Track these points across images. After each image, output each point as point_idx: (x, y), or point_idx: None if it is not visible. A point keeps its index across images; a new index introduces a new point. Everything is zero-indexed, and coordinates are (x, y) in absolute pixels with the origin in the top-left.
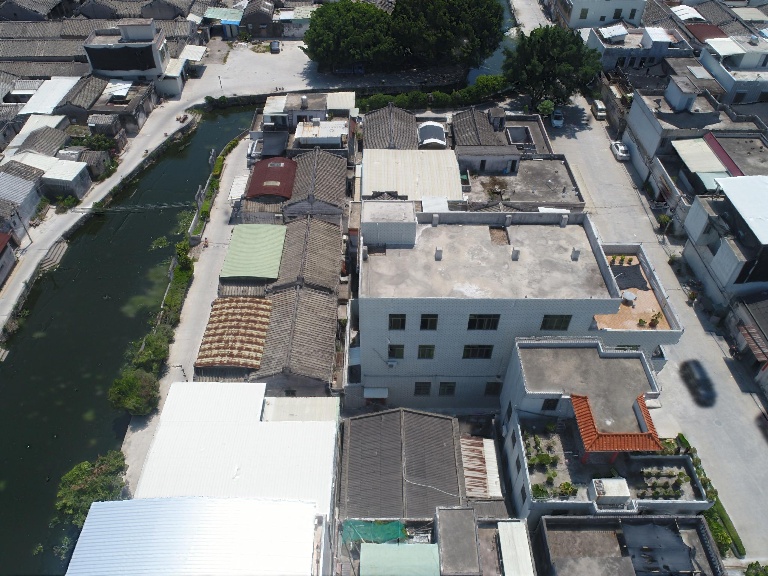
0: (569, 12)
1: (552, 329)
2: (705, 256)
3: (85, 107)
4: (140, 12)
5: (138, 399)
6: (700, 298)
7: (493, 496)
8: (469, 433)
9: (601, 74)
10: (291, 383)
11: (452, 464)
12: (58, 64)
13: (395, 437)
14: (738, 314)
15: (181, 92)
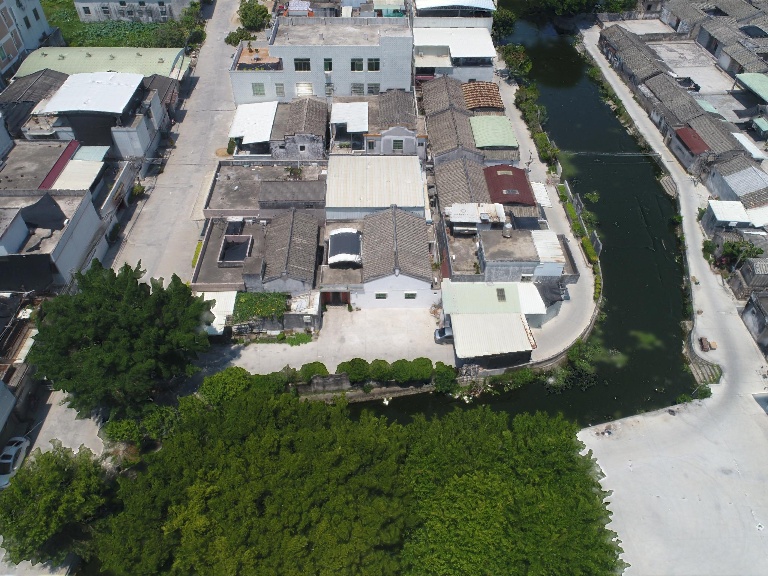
0: None
1: None
2: None
3: None
4: None
5: None
6: None
7: None
8: None
9: None
10: None
11: None
12: None
13: None
14: None
15: (767, 411)
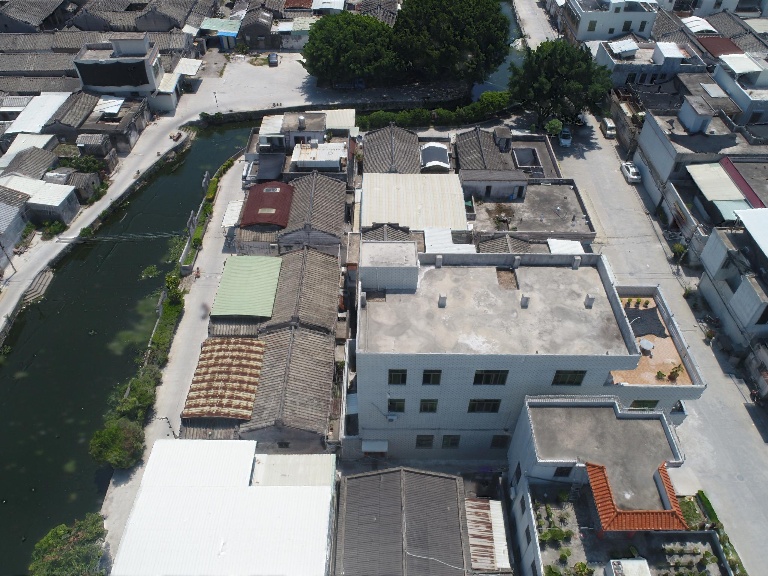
0: (577, 24)
1: (564, 384)
2: (723, 291)
3: (75, 126)
4: (134, 23)
5: (121, 452)
6: (718, 336)
7: (501, 567)
8: (474, 492)
9: (611, 91)
10: (284, 435)
11: (456, 531)
12: (48, 79)
13: (395, 501)
14: (760, 356)
15: (175, 108)
